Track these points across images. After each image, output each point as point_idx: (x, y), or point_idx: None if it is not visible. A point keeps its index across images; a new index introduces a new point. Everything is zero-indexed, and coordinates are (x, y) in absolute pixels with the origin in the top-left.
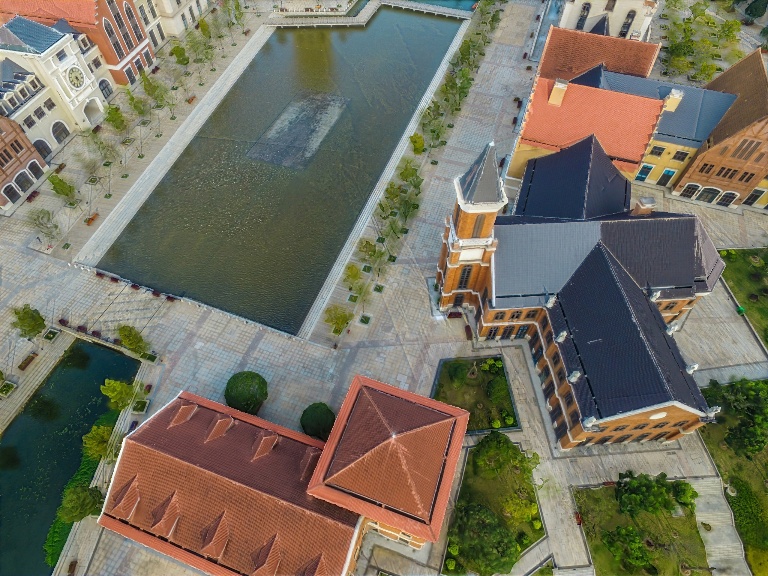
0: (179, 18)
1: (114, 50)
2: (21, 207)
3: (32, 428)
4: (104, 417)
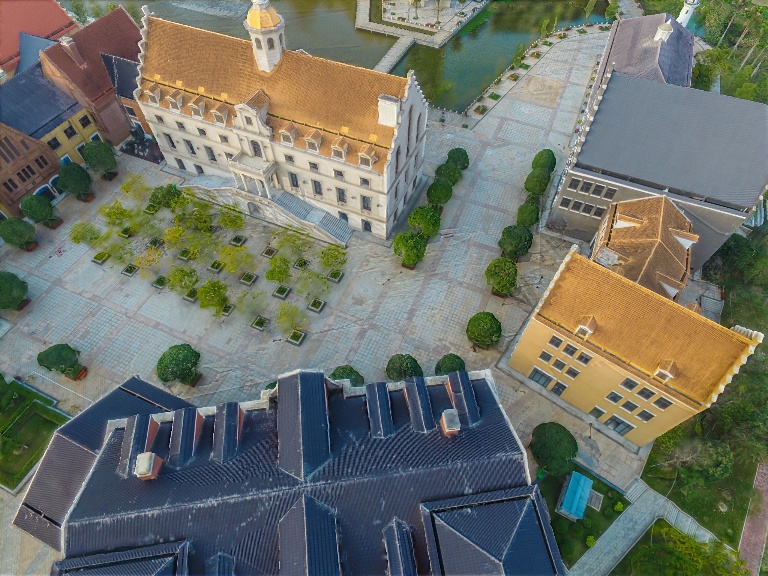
0: None
1: None
2: None
3: None
4: None
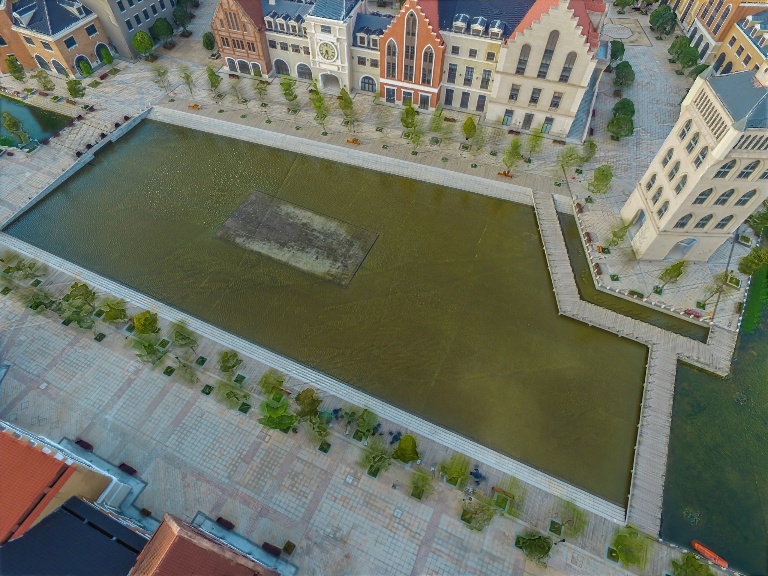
0: (501, 109)
1: (386, 66)
2: (226, 74)
3: (28, 115)
4: (10, 141)
